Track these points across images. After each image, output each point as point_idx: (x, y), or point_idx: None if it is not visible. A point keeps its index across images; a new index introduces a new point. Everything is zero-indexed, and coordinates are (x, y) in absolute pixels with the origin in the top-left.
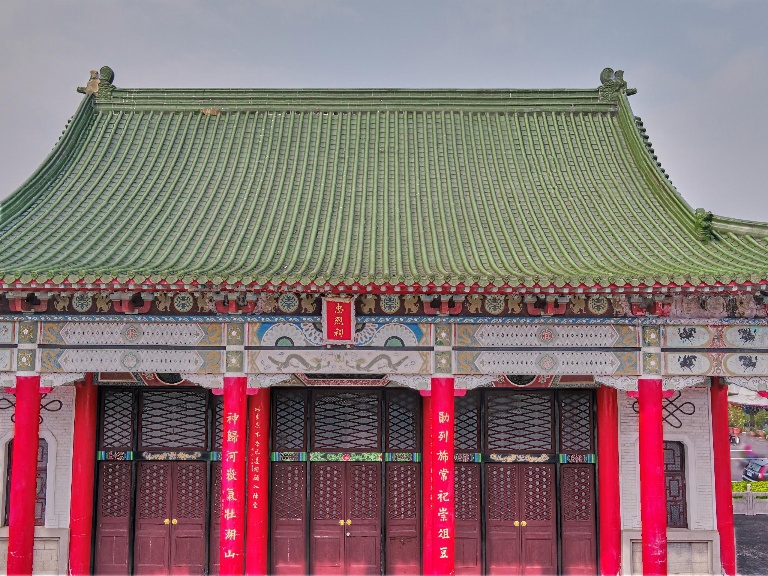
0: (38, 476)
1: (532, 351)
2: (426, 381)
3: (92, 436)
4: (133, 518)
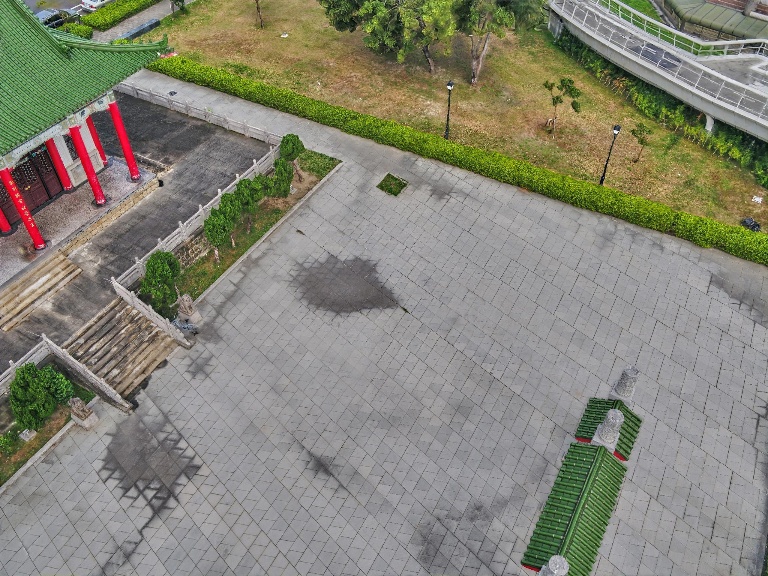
0: None
1: (31, 140)
2: None
3: None
4: None
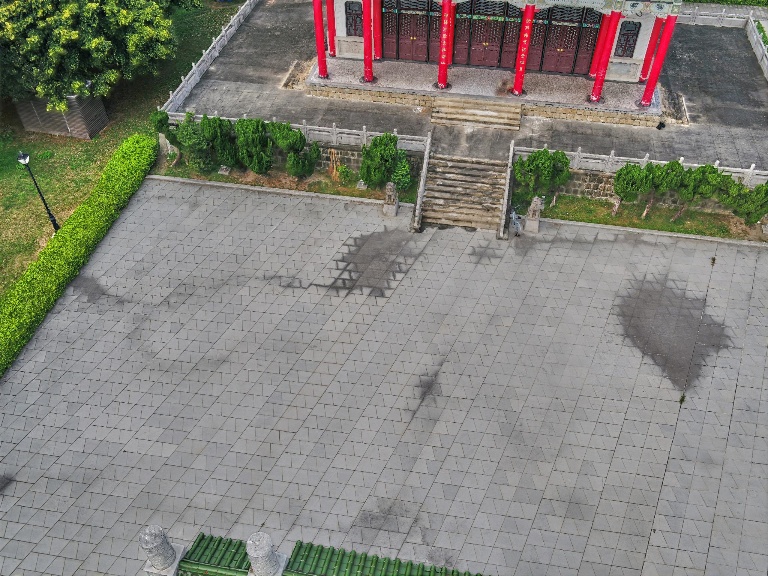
0: (358, 17)
1: None
2: (524, 5)
3: (380, 2)
4: (398, 36)
